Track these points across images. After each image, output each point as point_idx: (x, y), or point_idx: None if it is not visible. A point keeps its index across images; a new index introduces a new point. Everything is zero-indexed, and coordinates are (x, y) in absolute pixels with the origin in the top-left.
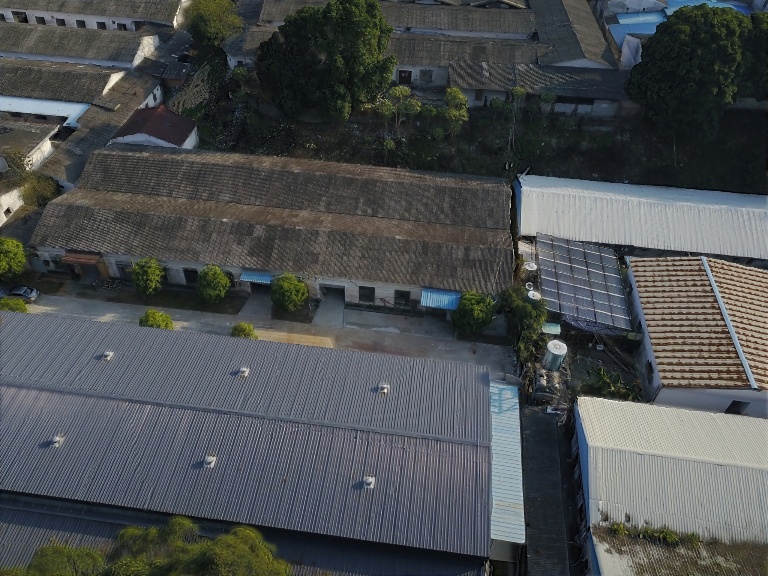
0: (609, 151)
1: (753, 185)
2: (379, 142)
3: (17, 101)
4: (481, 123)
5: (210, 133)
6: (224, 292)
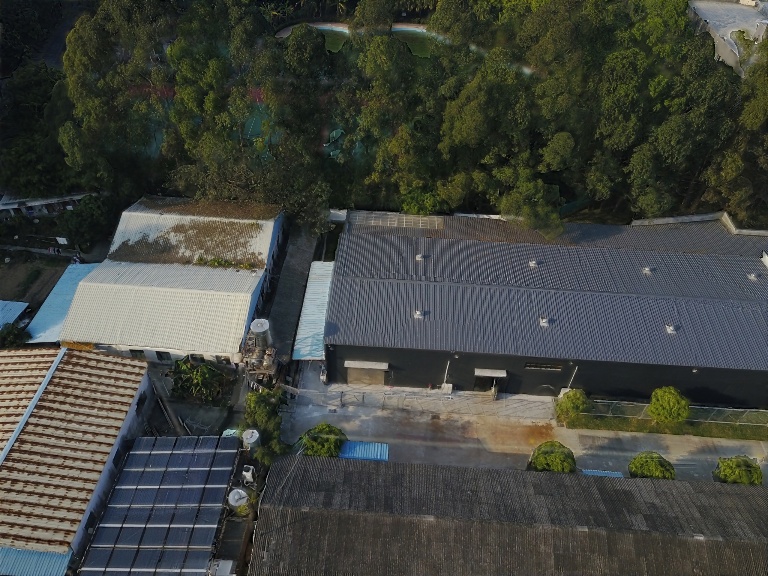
0: None
1: None
2: None
3: None
4: None
5: None
6: (631, 463)
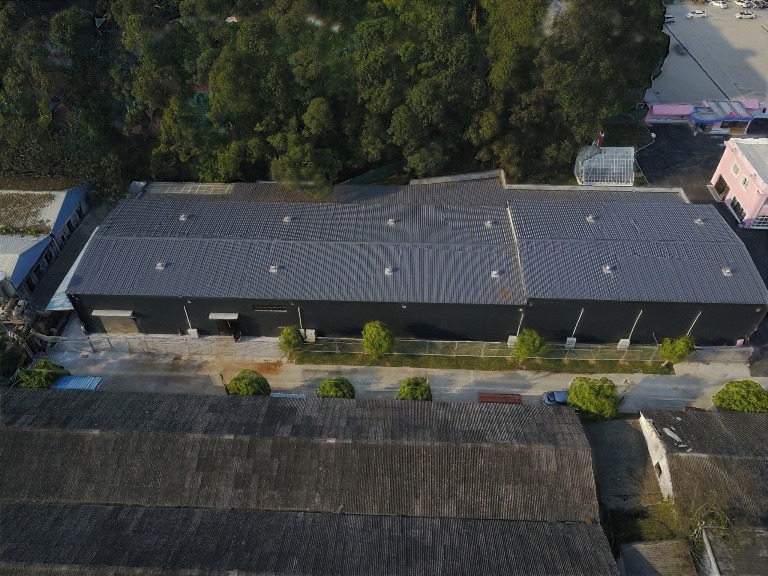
0: None
1: None
2: None
3: None
4: None
5: None
6: None
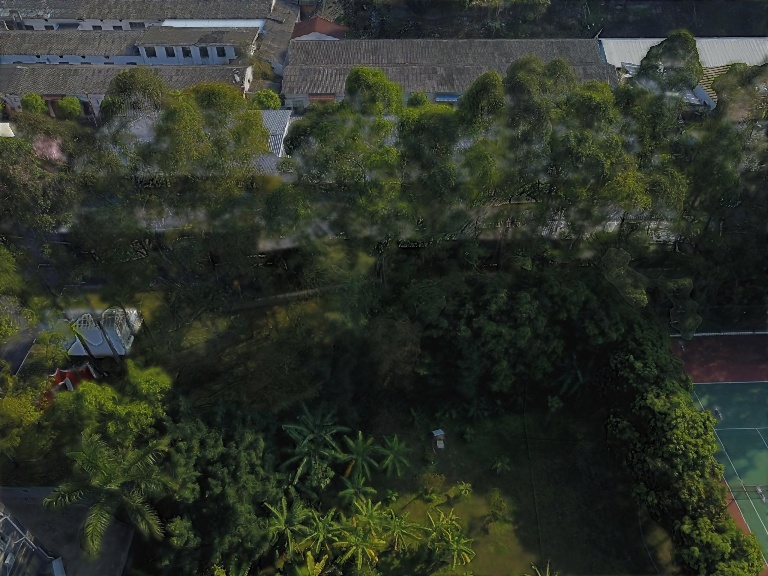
0: (649, 20)
1: (752, 34)
2: (485, 28)
3: (207, 22)
4: (558, 7)
5: (354, 36)
6: None
